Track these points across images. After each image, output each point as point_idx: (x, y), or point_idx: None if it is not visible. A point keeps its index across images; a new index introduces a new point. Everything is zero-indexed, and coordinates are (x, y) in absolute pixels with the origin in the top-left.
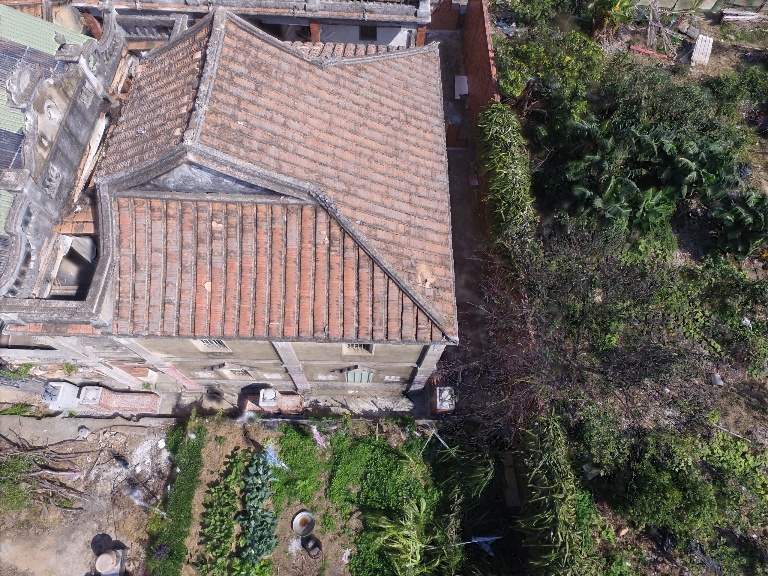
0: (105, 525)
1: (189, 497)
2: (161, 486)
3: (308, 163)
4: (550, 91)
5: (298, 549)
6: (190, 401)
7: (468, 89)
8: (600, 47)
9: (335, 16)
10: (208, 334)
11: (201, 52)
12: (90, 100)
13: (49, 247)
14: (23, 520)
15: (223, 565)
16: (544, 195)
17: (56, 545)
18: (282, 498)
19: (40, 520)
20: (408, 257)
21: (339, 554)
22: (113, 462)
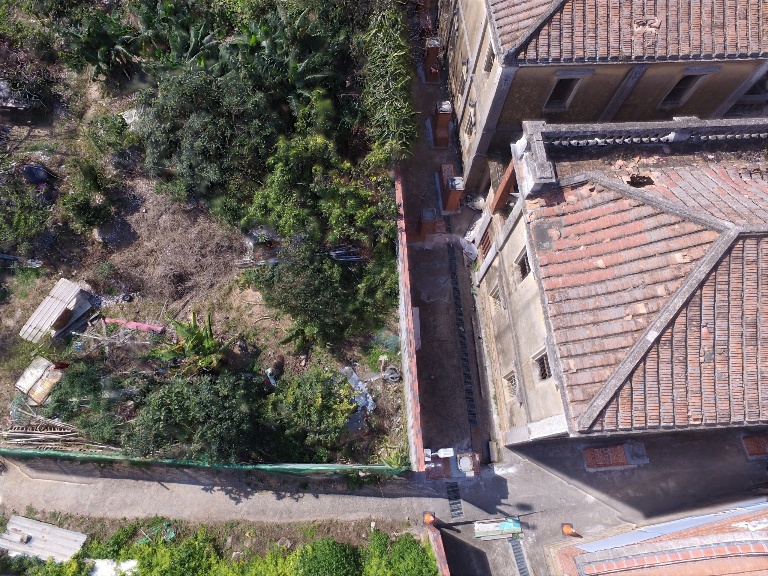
0: None
1: None
2: None
3: None
4: None
5: None
6: None
7: None
8: None
9: None
10: None
11: None
12: None
13: None
14: None
15: None
16: None
17: None
18: None
19: None
20: None
21: None
22: None
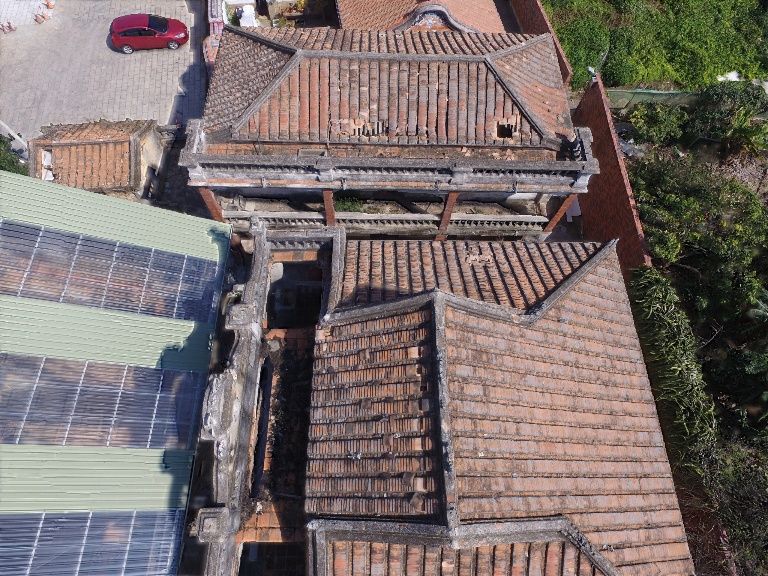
0: None
1: None
2: None
3: (549, 483)
4: (705, 250)
5: None
6: None
7: (581, 210)
8: (732, 171)
9: (482, 188)
10: None
11: (419, 351)
12: (254, 355)
13: (234, 565)
14: None
15: None
16: (707, 376)
17: None
18: None
19: None
20: (655, 575)
21: None
22: None
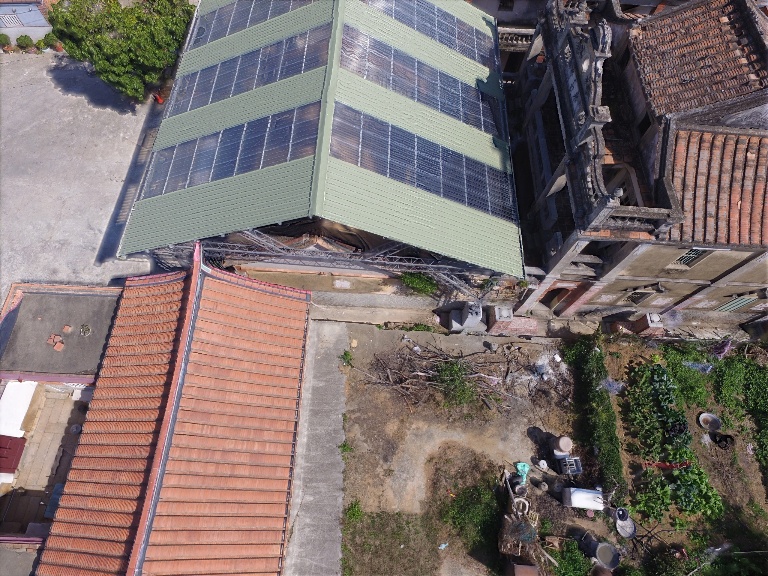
0: (533, 420)
1: (608, 398)
2: (571, 391)
3: None
4: None
5: (709, 442)
6: (559, 327)
7: None
8: None
9: None
10: (739, 243)
11: (730, 17)
12: None
13: None
14: (466, 413)
15: (657, 450)
16: None
17: (499, 434)
18: (682, 402)
19: (481, 414)
20: None
21: (743, 447)
22: (522, 371)
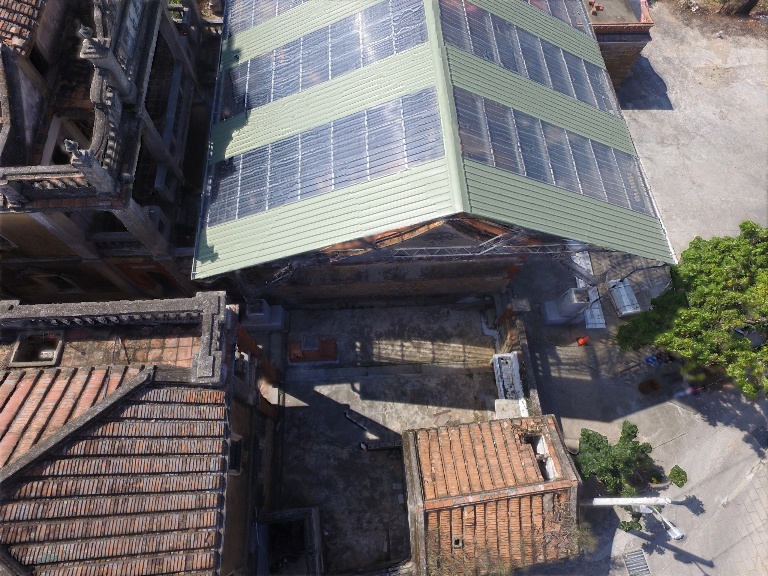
0: None
1: None
2: None
3: None
4: None
5: None
6: None
7: None
8: None
9: None
10: None
11: None
12: None
13: None
14: None
15: None
16: None
17: None
18: None
19: None
20: None
21: None
22: None
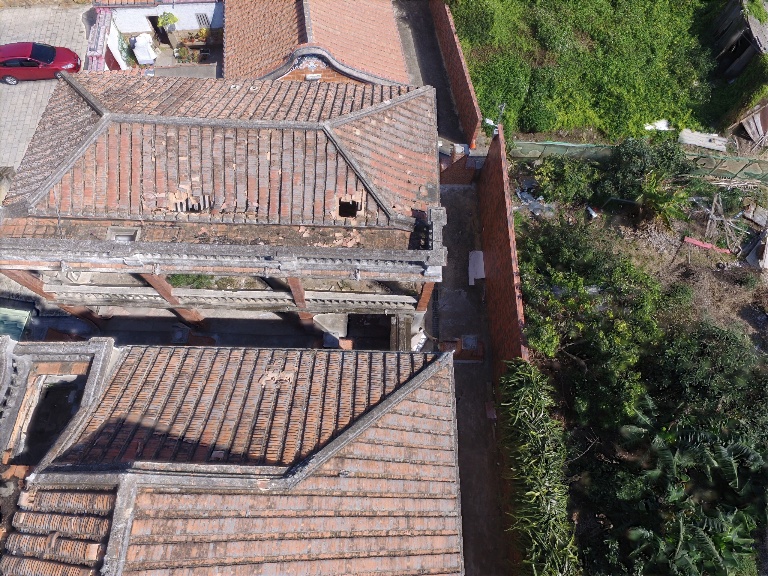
0: None
1: None
2: None
3: None
4: None
5: None
6: None
7: (484, 272)
8: (647, 236)
9: (318, 276)
10: None
11: None
12: None
13: None
14: None
15: None
16: None
17: None
18: None
19: None
20: None
21: None
22: None
